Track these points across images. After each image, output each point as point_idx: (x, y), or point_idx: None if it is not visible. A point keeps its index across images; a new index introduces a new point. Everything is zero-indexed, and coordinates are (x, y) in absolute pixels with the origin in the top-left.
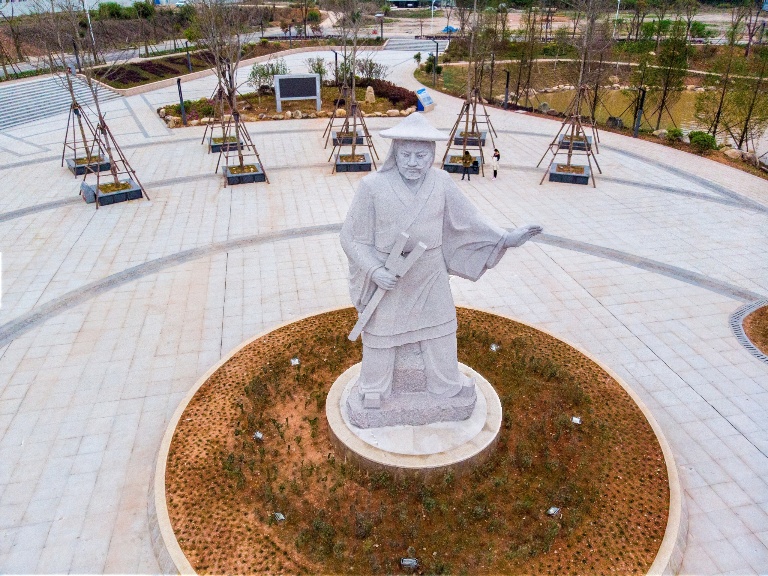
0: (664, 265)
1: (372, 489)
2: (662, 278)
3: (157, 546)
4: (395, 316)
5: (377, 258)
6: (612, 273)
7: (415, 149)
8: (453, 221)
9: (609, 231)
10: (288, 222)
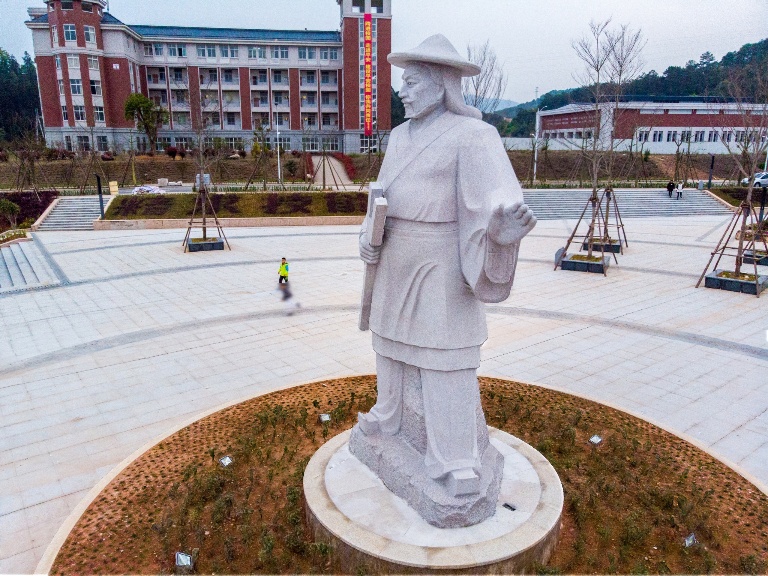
0: None
1: (288, 504)
2: None
3: None
4: (384, 309)
5: None
6: None
7: (405, 74)
8: (468, 195)
9: None
10: (708, 329)
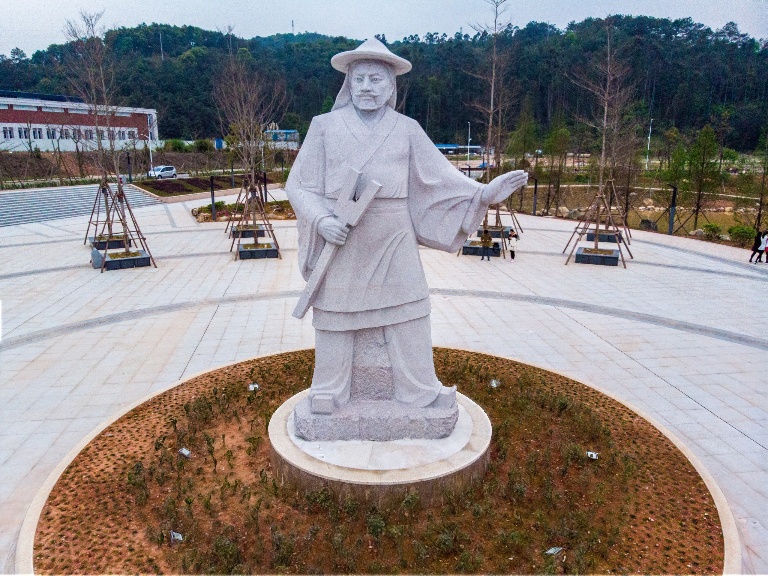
0: (706, 327)
1: (308, 513)
2: (704, 338)
3: (8, 566)
4: (349, 285)
5: (326, 208)
6: (644, 332)
7: (368, 71)
8: (421, 174)
9: (641, 300)
10: (290, 286)
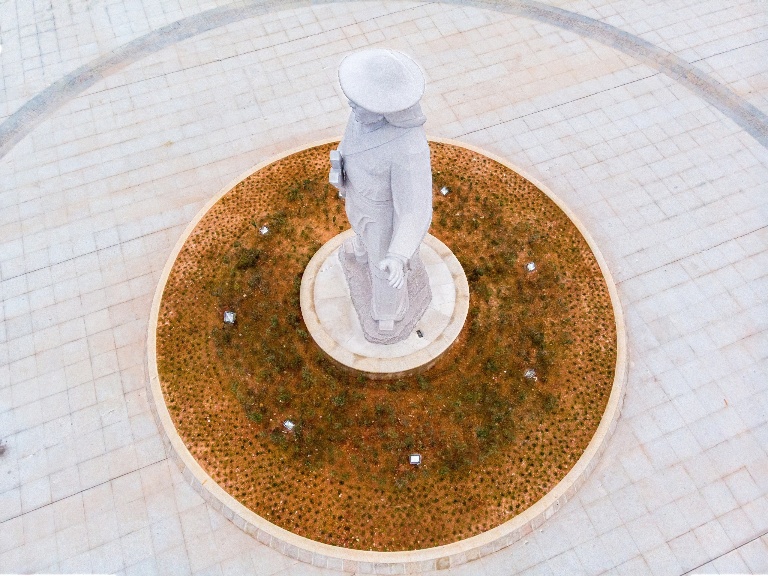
0: None
1: None
2: None
3: None
4: None
5: None
6: None
7: None
8: None
9: None
10: None
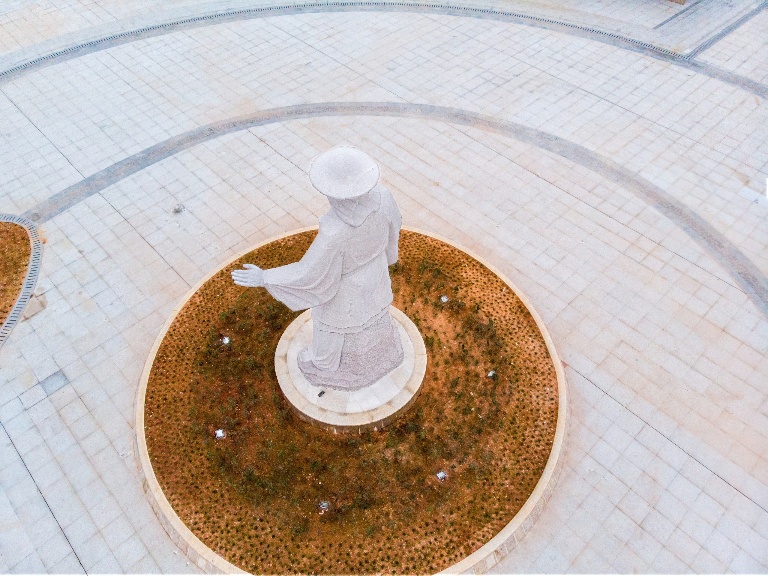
0: None
1: None
2: None
3: None
4: None
5: None
6: None
7: None
8: None
9: None
10: None
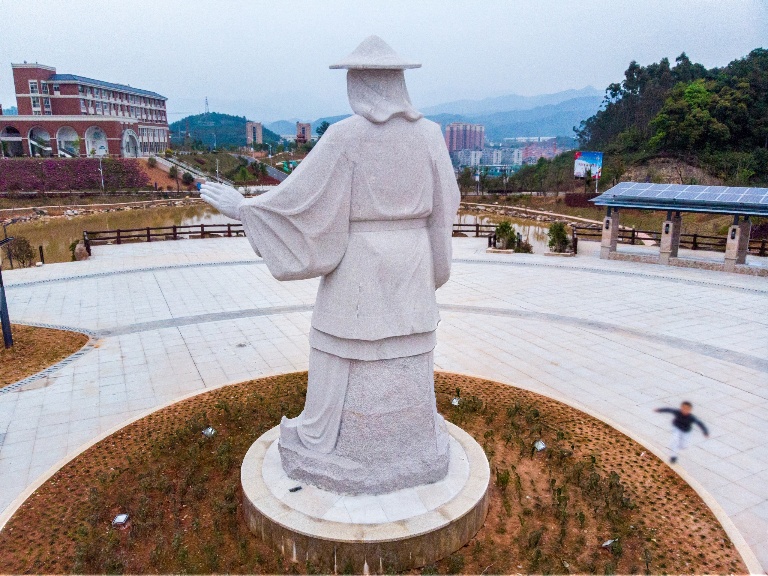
0: None
1: None
2: None
3: None
4: None
5: None
6: None
7: None
8: None
9: None
10: None
